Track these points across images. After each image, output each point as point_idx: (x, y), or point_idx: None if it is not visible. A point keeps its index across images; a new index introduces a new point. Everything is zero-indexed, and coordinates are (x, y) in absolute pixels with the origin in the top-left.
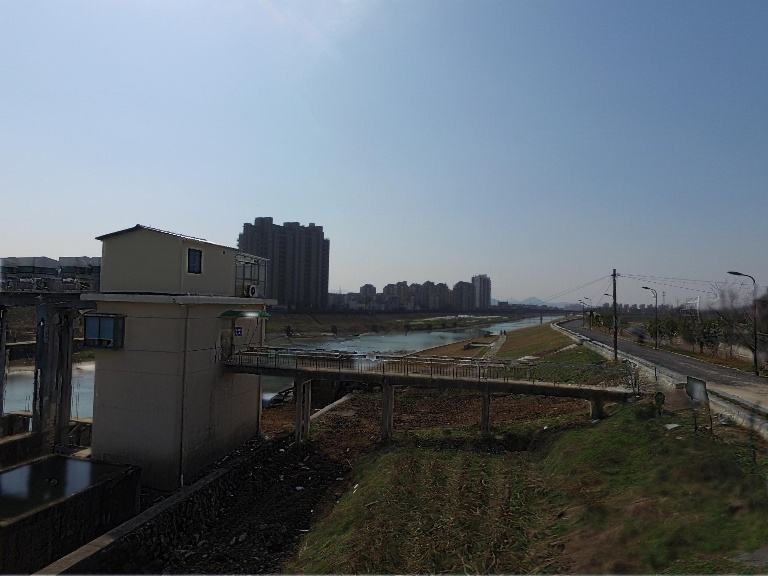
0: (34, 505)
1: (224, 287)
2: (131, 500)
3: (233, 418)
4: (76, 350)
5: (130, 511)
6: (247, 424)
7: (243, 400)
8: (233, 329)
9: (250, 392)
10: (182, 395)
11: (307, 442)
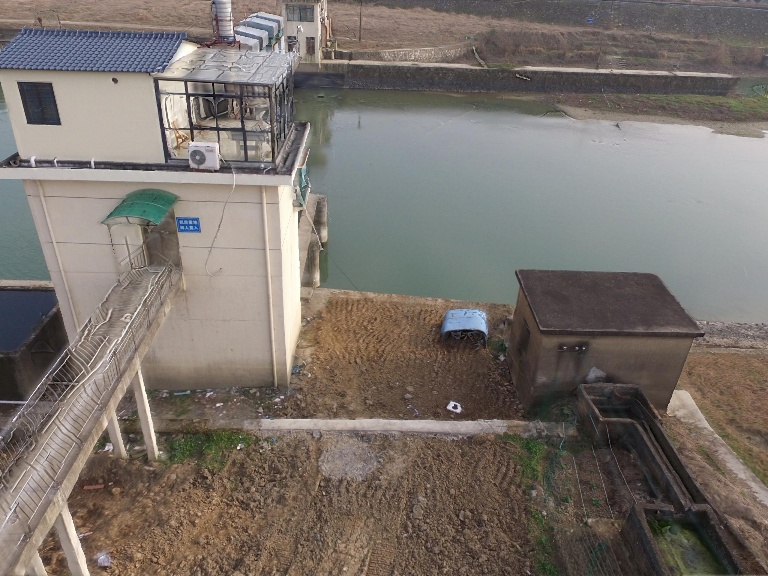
0: (31, 330)
1: (132, 146)
2: (11, 382)
3: (201, 348)
4: (669, 90)
5: (14, 391)
6: (243, 365)
7: (225, 330)
8: (175, 219)
9: (245, 322)
10: (68, 296)
11: (131, 464)
